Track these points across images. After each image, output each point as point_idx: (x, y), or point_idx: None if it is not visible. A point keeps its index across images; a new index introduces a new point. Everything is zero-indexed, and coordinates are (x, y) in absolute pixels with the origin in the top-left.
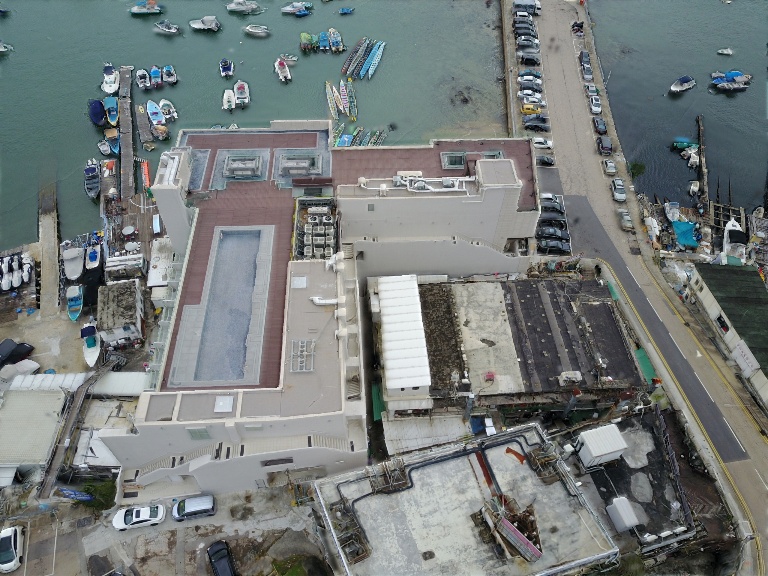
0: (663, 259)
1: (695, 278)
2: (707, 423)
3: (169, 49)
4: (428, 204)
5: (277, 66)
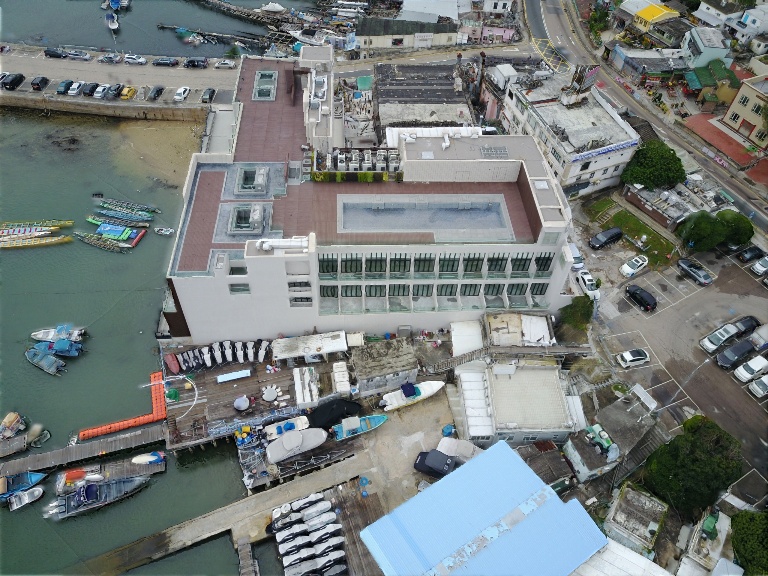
0: None
1: (363, 42)
2: None
3: None
4: None
5: None
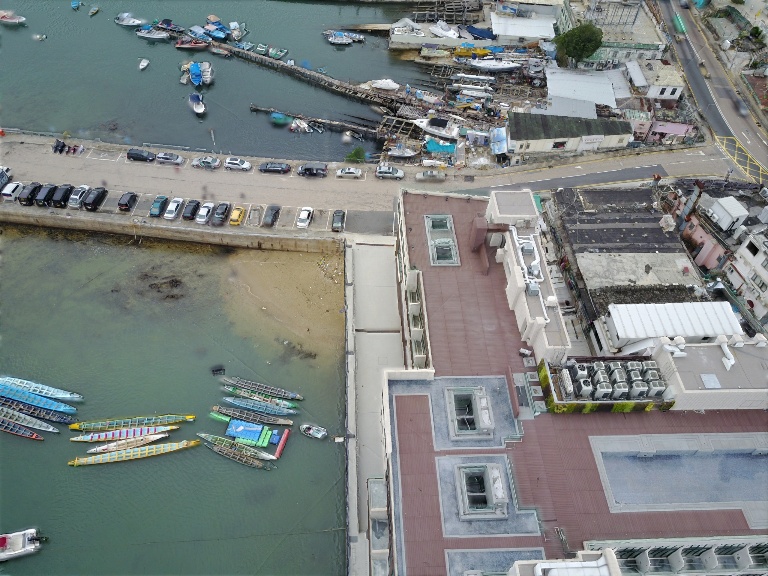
0: None
1: (519, 146)
2: (641, 176)
3: None
4: None
5: None
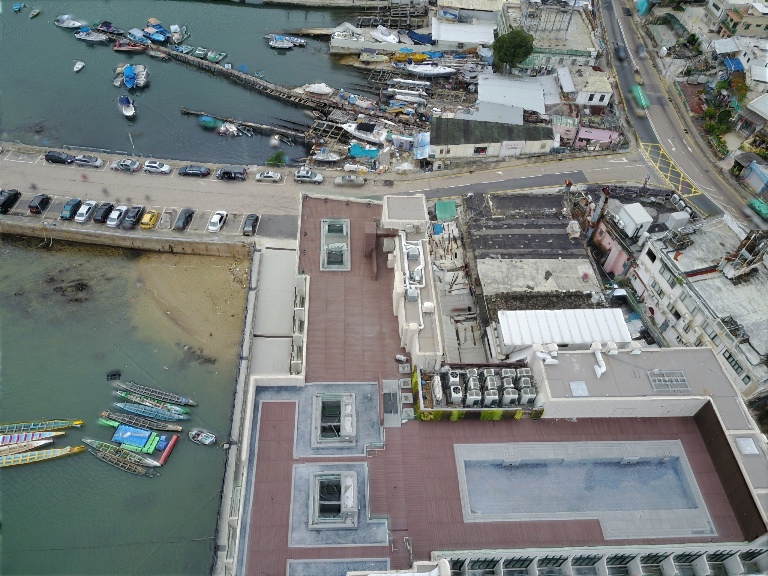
0: None
1: (439, 151)
2: (560, 182)
3: None
4: None
5: None
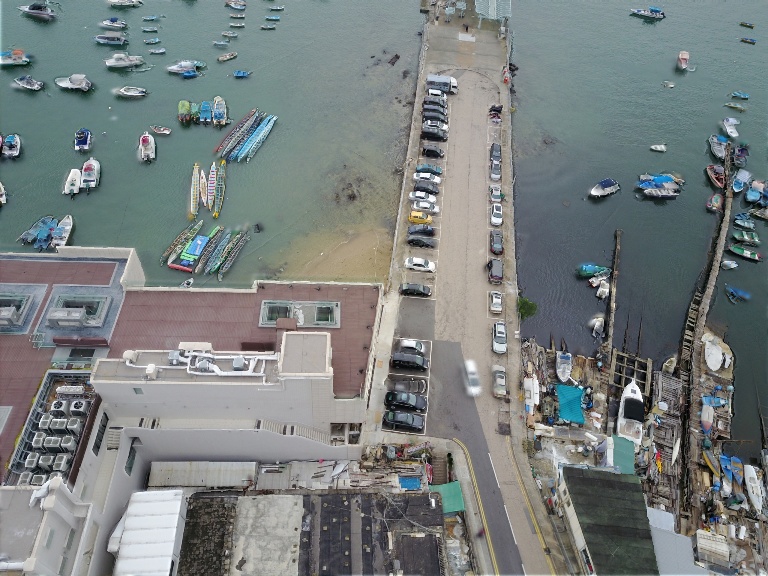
0: (539, 438)
1: (563, 486)
2: None
3: (28, 109)
4: (214, 390)
5: (141, 141)
